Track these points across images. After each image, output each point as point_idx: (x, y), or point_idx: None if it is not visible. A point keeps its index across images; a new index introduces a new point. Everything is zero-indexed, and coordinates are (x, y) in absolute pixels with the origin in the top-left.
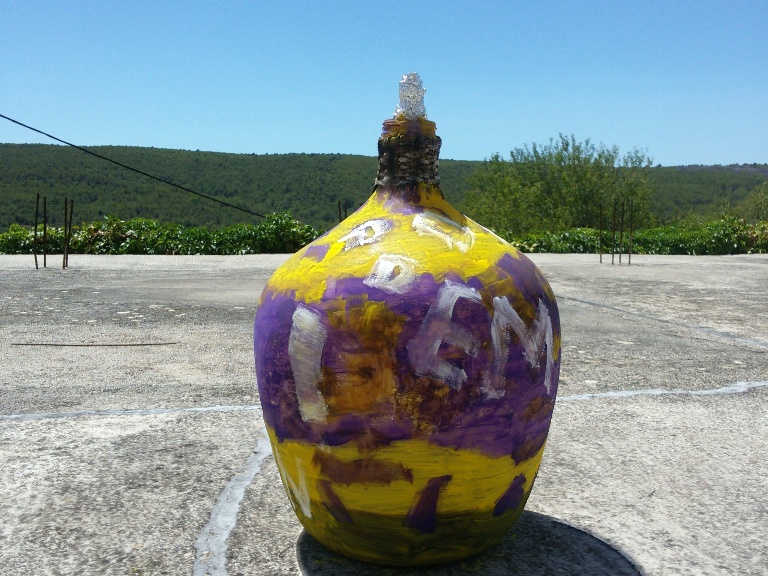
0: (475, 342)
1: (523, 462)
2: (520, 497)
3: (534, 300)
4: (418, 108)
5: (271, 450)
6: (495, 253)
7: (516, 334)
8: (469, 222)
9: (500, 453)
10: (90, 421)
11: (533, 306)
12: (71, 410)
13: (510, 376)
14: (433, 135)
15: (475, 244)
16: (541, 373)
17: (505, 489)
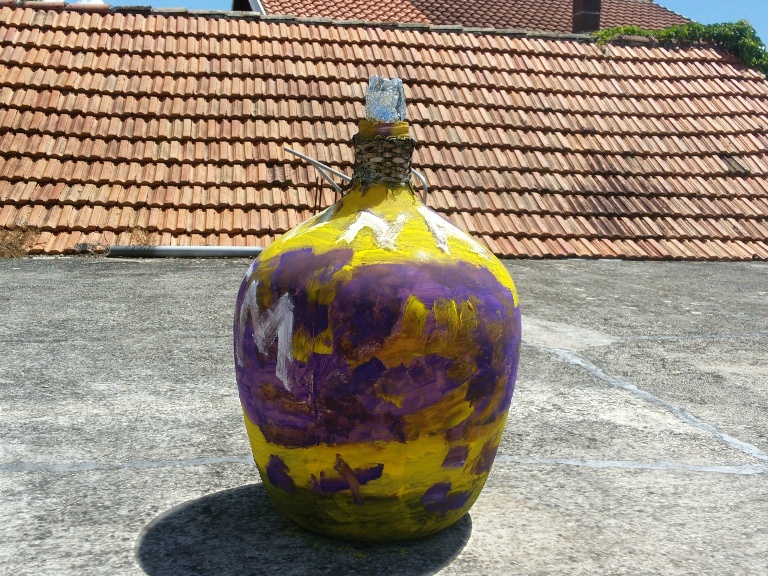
0: (236, 313)
1: (275, 444)
2: (291, 484)
3: (279, 292)
4: (371, 111)
5: (595, 465)
6: (298, 246)
7: (251, 316)
8: (347, 218)
9: (253, 420)
10: (645, 410)
11: (274, 297)
12: (677, 403)
13: (245, 351)
14: (369, 135)
15: (299, 236)
16: (269, 362)
17: (268, 461)
